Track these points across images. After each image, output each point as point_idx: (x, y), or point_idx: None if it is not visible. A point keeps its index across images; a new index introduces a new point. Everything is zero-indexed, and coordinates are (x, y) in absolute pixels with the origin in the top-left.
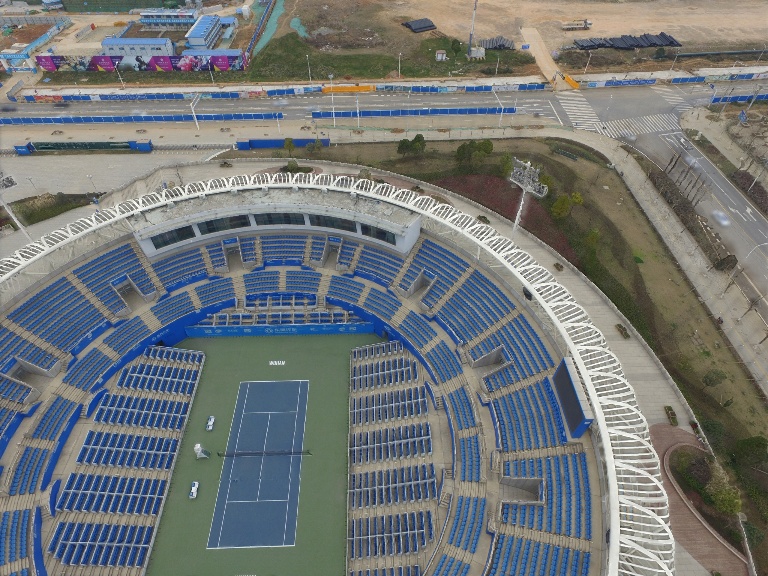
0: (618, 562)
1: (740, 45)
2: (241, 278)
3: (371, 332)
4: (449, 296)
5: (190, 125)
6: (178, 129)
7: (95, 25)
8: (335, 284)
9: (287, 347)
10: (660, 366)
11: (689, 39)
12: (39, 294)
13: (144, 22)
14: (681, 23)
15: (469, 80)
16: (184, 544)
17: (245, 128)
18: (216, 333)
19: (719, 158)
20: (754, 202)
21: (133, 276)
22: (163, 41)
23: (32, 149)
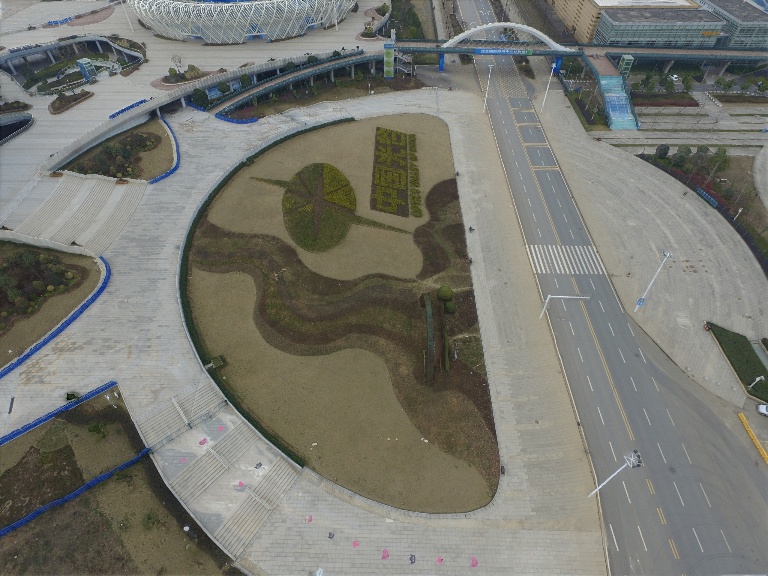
0: None
1: None
2: None
3: None
4: None
5: None
6: None
7: None
8: None
9: None
10: None
11: None
12: None
13: None
14: None
15: None
16: None
17: None
18: None
19: None
20: None
21: None
22: None
23: None
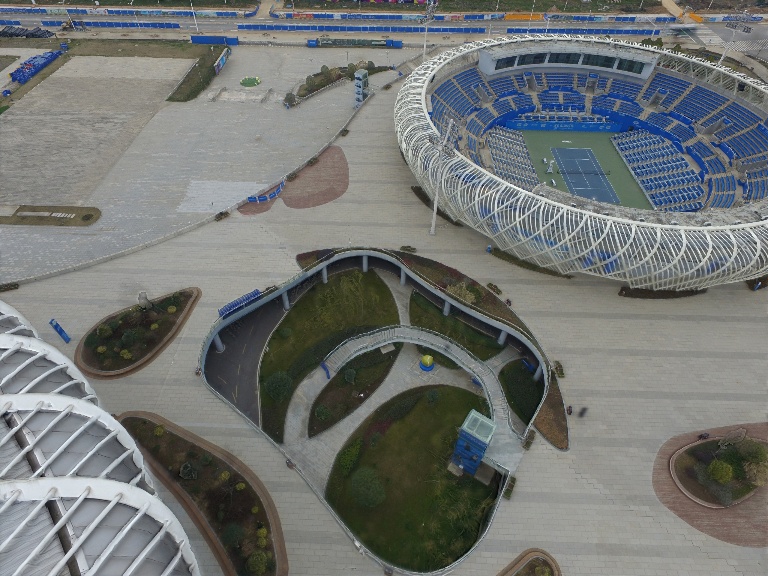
0: None
1: None
2: (536, 96)
3: (618, 131)
4: (679, 101)
5: (417, 35)
6: (410, 37)
7: None
8: (596, 101)
9: (568, 136)
10: None
11: None
12: (443, 85)
13: None
14: None
15: (613, 15)
16: None
17: (459, 38)
18: (523, 127)
19: None
20: None
21: None
22: None
23: (317, 43)
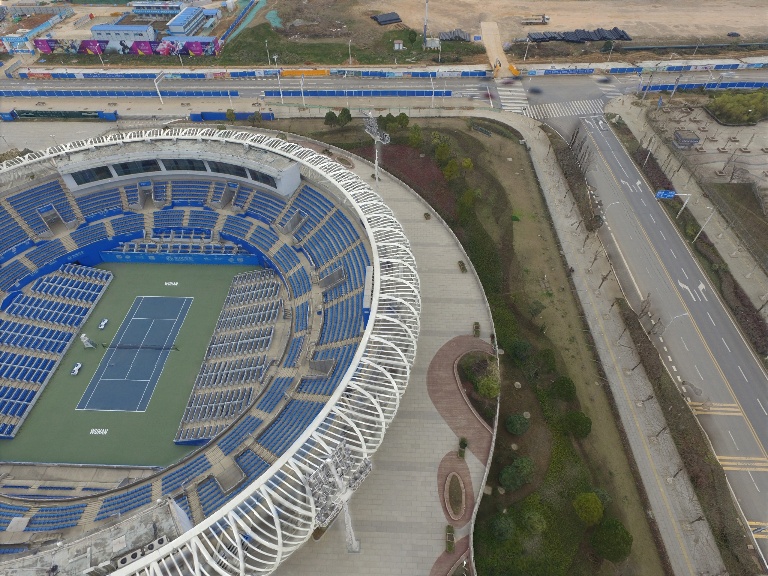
0: (339, 397)
1: (690, 40)
2: (151, 215)
3: (257, 264)
4: (315, 231)
5: (156, 100)
6: (145, 103)
7: (94, 15)
8: (229, 222)
9: (183, 273)
10: (483, 293)
11: (641, 34)
12: None
13: (136, 12)
14: (639, 19)
15: (419, 67)
16: (59, 405)
17: (203, 104)
18: (126, 259)
19: (629, 138)
20: (646, 176)
21: (58, 207)
22: (145, 28)
23: (15, 116)
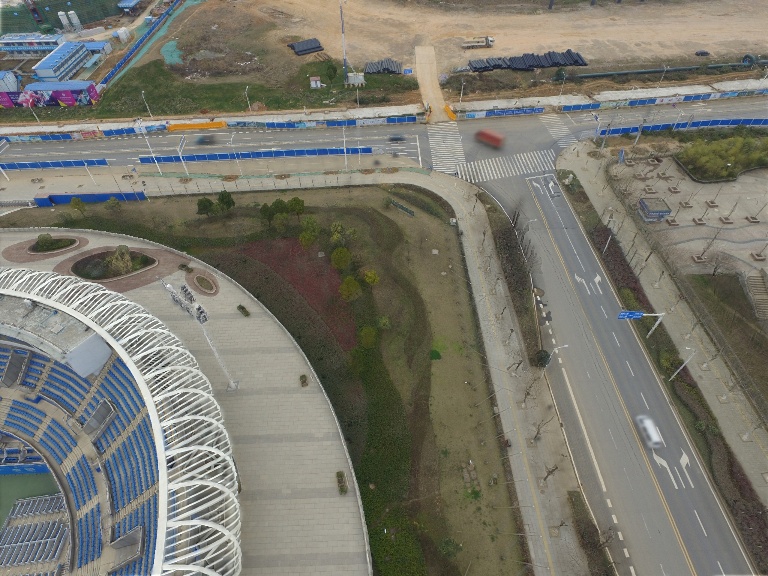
0: None
1: (654, 62)
2: None
3: None
4: (122, 439)
5: (2, 175)
6: None
7: None
8: (14, 411)
9: None
10: (364, 542)
11: (598, 56)
12: None
13: (5, 50)
14: (596, 37)
15: (338, 111)
16: None
17: (61, 178)
18: None
19: (585, 208)
20: (607, 268)
21: None
22: (1, 75)
23: None
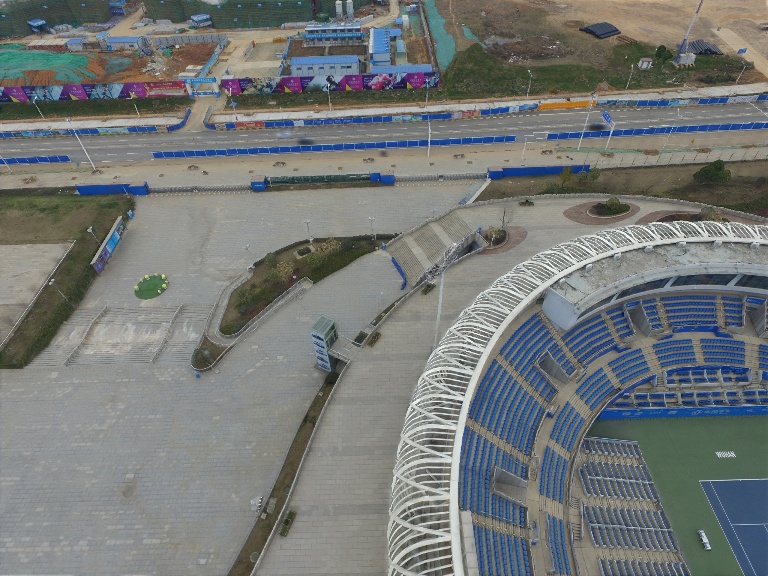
0: None
1: None
2: (650, 348)
3: None
4: None
5: (415, 151)
6: (406, 156)
7: (254, 42)
8: (766, 355)
9: (723, 432)
10: None
11: None
12: (482, 383)
13: (308, 37)
14: None
15: (690, 90)
16: None
17: (478, 153)
18: (633, 415)
19: None
20: None
21: None
22: (354, 59)
23: (266, 184)
